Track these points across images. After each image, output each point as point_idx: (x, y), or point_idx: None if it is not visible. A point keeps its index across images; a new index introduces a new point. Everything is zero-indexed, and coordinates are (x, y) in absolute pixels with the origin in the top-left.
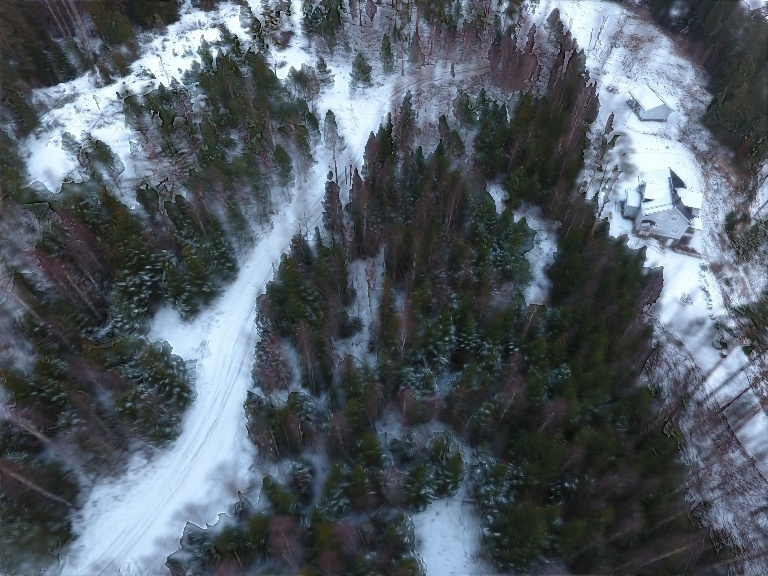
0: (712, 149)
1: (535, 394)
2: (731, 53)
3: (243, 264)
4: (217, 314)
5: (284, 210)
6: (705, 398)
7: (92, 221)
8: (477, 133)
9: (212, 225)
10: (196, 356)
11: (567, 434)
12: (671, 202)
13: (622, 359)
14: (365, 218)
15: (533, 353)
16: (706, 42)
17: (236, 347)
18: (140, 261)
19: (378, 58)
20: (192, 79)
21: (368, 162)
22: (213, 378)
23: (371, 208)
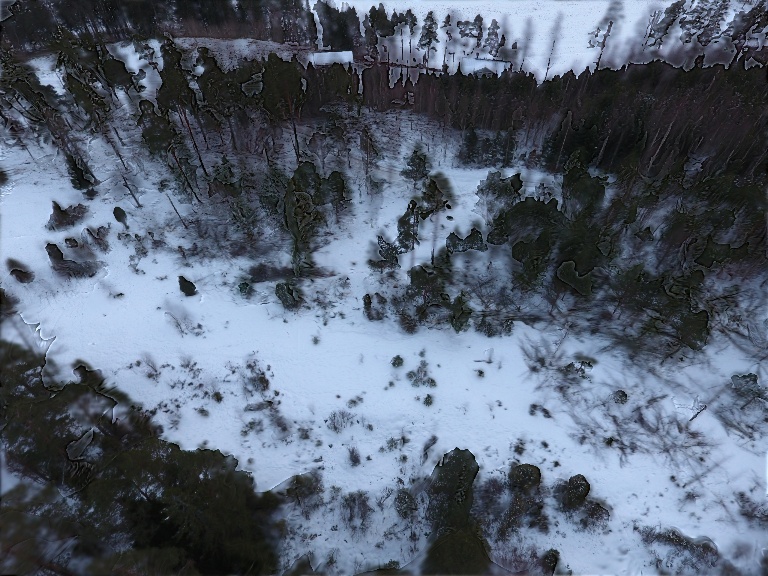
0: None
1: None
2: (279, 8)
3: None
4: None
5: None
6: None
7: None
8: (502, 105)
9: None
10: None
11: (761, 81)
12: (505, 62)
13: None
14: None
15: None
16: (232, 18)
17: None
18: None
19: None
20: None
21: None
22: None
23: None
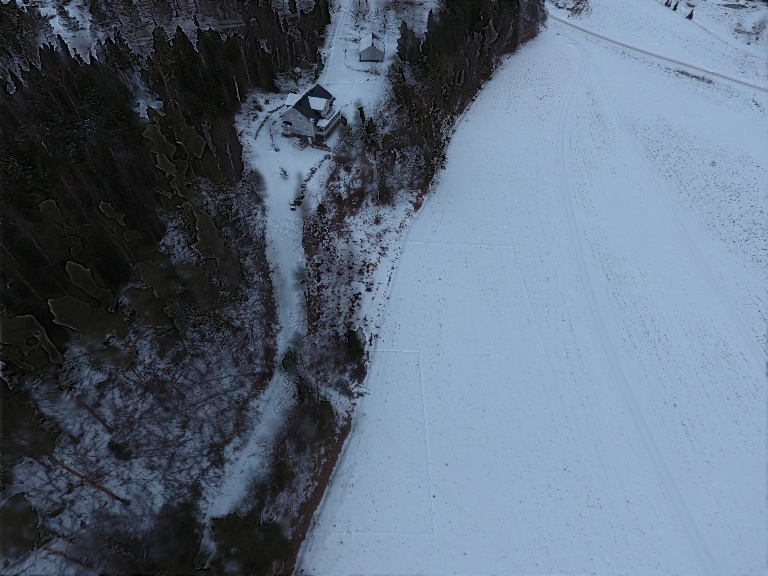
0: (420, 84)
1: (4, 180)
2: None
3: None
4: None
5: None
6: (250, 231)
7: None
8: None
9: None
10: None
11: None
12: None
13: (114, 175)
14: None
15: None
16: None
17: None
18: None
19: (122, 9)
20: None
21: None
22: None
23: (2, 93)
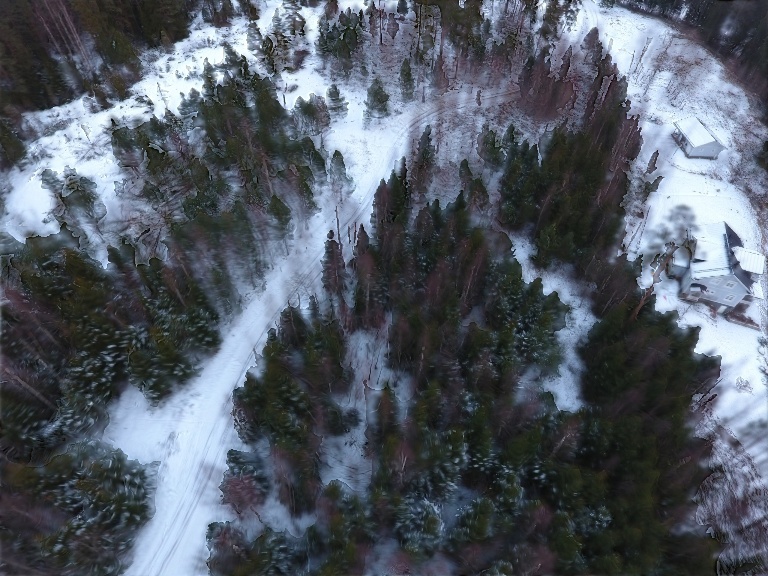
0: None
1: (566, 556)
2: None
3: (228, 332)
4: (192, 396)
5: (280, 264)
6: None
7: (52, 288)
8: (503, 177)
9: (191, 292)
10: (162, 452)
11: None
12: (727, 266)
13: (675, 495)
14: (368, 289)
15: (564, 487)
16: (762, 68)
17: (210, 442)
18: (102, 340)
19: (397, 84)
20: (190, 109)
21: (378, 211)
22: (179, 483)
23: (376, 276)
